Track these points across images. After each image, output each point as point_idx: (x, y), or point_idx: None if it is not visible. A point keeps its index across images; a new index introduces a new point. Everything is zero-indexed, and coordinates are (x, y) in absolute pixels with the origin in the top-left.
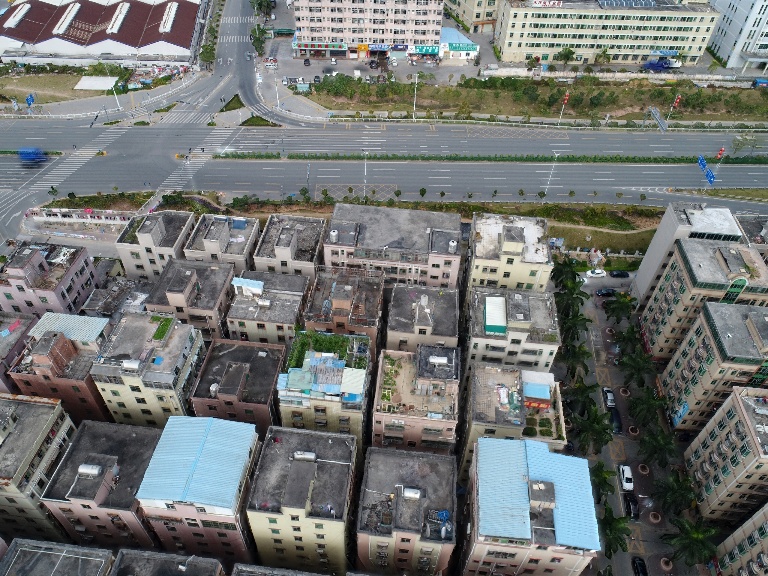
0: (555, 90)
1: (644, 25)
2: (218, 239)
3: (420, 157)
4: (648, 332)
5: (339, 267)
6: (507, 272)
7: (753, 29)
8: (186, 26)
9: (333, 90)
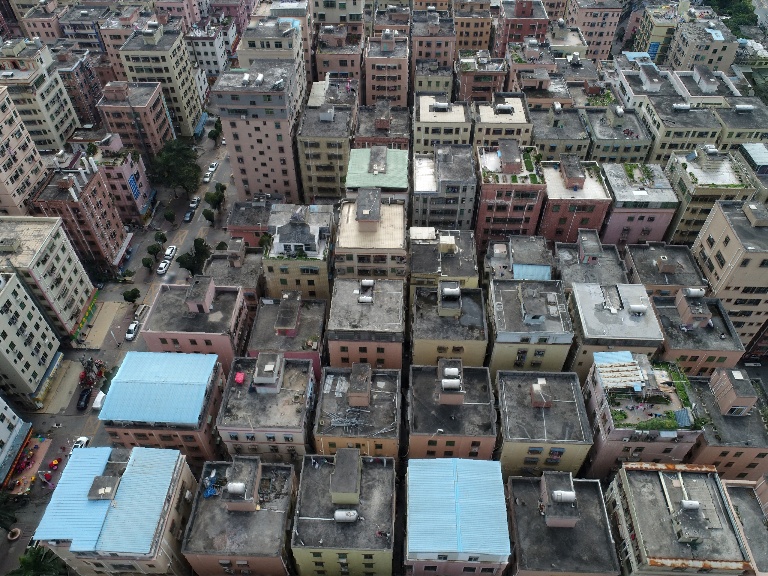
0: None
1: None
2: None
3: None
4: None
5: None
6: None
7: None
8: None
9: None
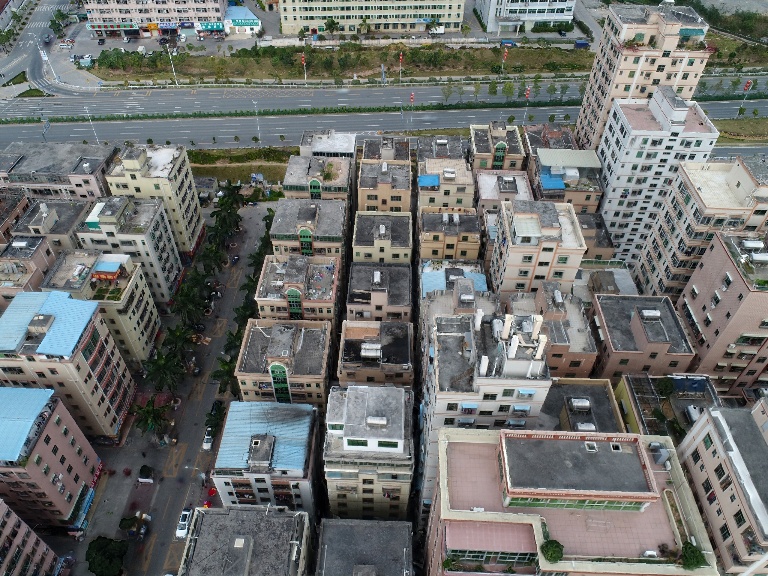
0: None
1: None
2: None
3: (168, 116)
4: None
5: None
6: (137, 187)
7: None
8: None
9: (107, 63)
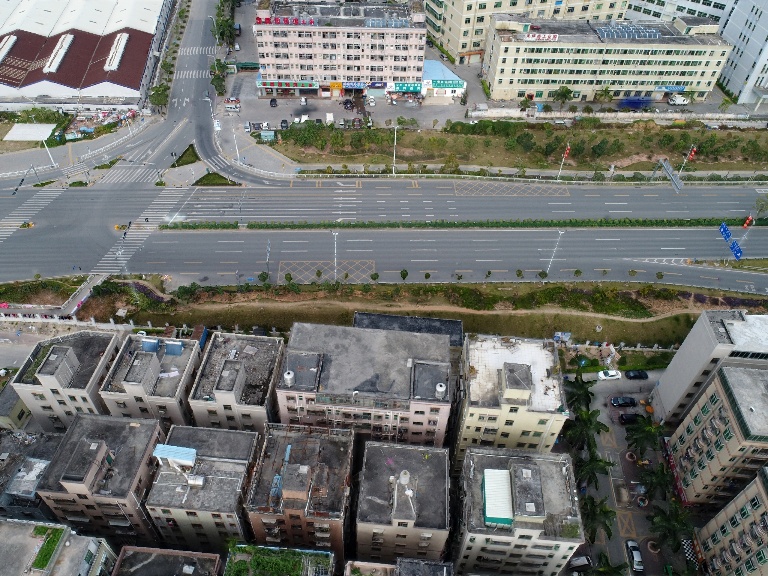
0: (552, 135)
1: (648, 59)
2: (141, 381)
3: (401, 224)
4: (679, 468)
5: (295, 425)
6: (510, 420)
7: (767, 63)
8: (136, 62)
9: (301, 140)
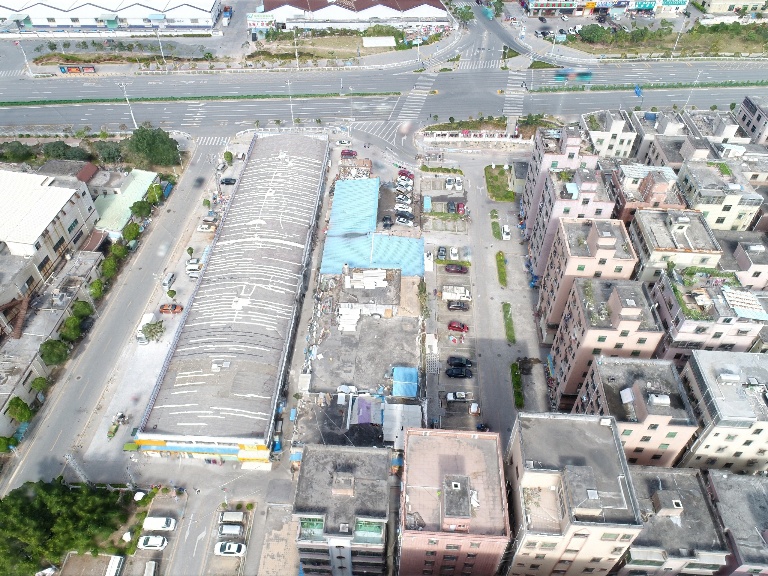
0: None
1: None
2: (679, 122)
3: (700, 85)
4: None
5: None
6: None
7: None
8: None
9: (595, 37)
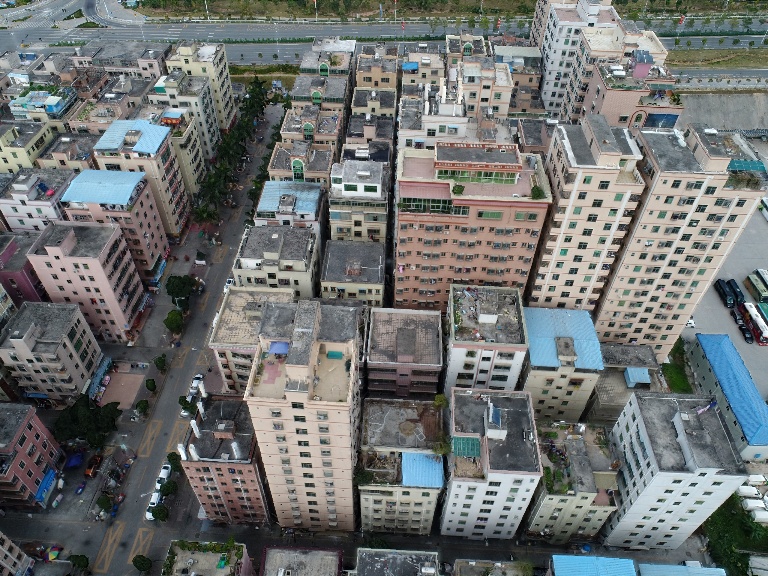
0: None
1: None
2: (7, 58)
3: None
4: None
5: (77, 66)
6: (189, 71)
7: None
8: None
9: (150, 2)
